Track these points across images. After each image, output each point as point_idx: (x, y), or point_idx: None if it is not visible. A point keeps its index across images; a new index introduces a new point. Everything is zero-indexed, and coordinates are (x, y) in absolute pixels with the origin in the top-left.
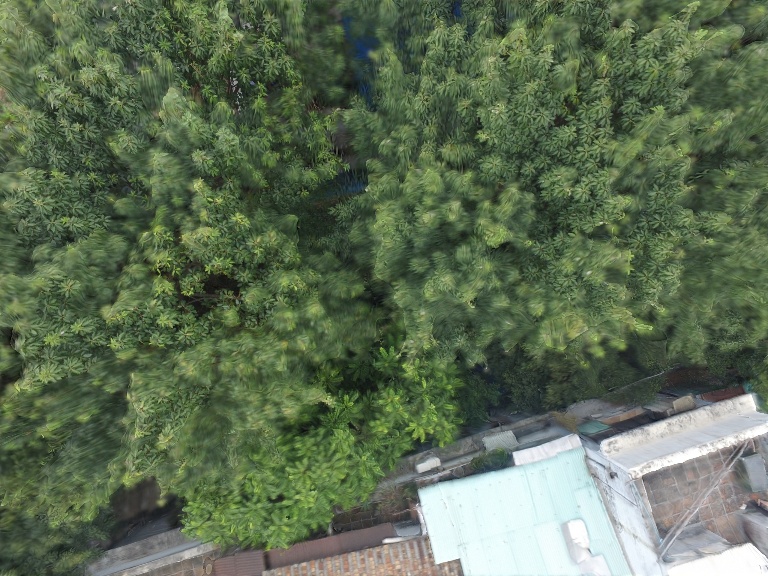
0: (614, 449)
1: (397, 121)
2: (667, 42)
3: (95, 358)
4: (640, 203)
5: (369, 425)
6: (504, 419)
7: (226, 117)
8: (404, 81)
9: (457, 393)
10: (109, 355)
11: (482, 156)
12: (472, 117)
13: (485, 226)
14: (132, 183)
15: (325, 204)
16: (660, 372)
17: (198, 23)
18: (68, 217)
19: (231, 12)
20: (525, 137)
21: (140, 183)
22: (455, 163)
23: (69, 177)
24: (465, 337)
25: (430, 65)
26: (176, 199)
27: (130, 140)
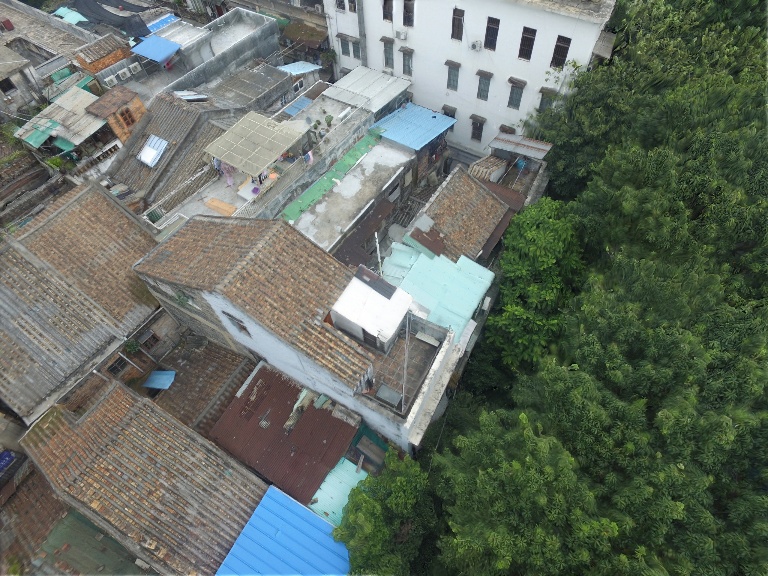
0: (455, 349)
1: None
2: (761, 362)
3: (691, 157)
4: None
5: None
6: None
7: None
8: None
9: (493, 367)
10: None
11: None
12: None
13: None
14: None
15: None
16: None
17: None
18: (762, 174)
19: None
20: None
21: None
22: None
23: None
24: None
25: None
26: None
27: None
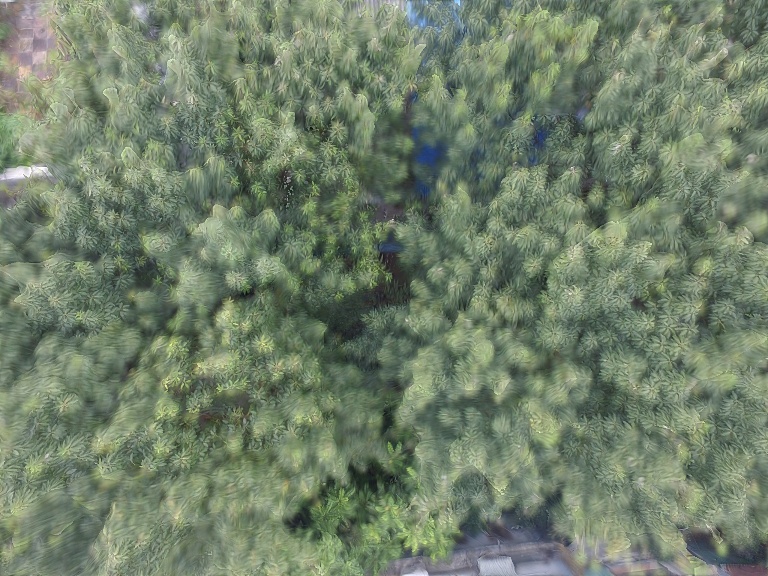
0: None
1: (453, 249)
2: None
3: (79, 472)
4: (712, 406)
5: (360, 527)
6: (504, 534)
7: (271, 226)
8: (469, 214)
9: None
10: (95, 470)
11: (541, 317)
12: (538, 275)
13: (533, 408)
14: (160, 268)
15: (359, 310)
16: (684, 527)
17: (260, 129)
18: (83, 311)
19: (298, 113)
20: (594, 309)
21: (168, 272)
22: (510, 318)
23: (93, 267)
24: (484, 490)
25: (501, 206)
26: (201, 305)
27: (164, 242)
